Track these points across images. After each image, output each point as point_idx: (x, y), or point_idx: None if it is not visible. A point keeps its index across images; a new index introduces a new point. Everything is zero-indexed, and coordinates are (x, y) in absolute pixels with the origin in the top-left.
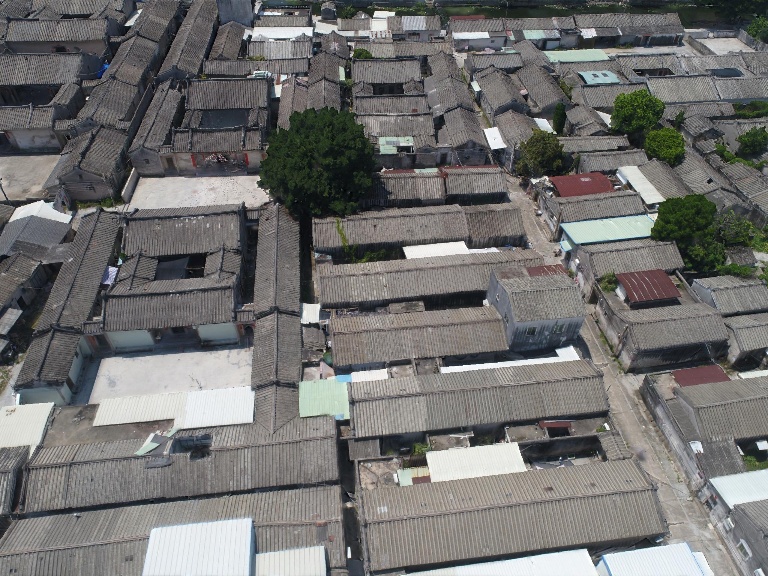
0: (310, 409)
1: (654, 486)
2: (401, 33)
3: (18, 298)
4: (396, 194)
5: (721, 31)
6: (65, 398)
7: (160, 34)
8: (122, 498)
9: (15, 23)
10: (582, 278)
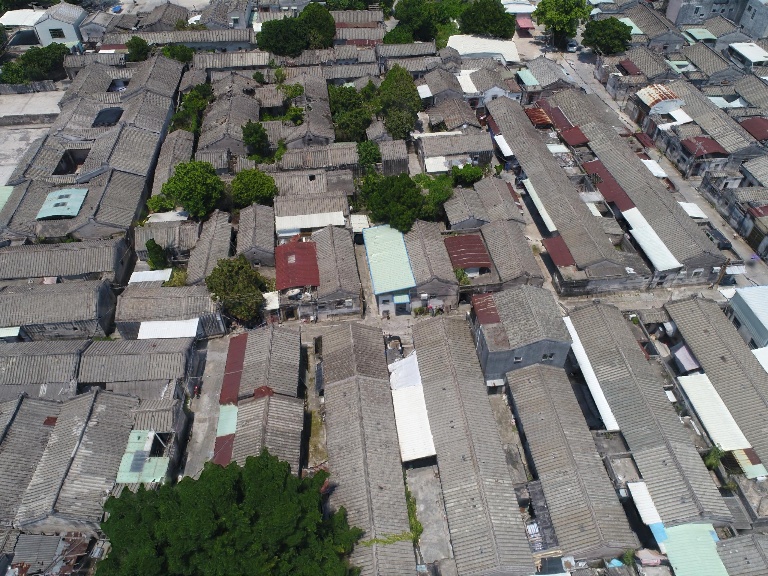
0: (719, 571)
1: (697, 295)
2: None
3: None
4: (290, 461)
5: None
6: None
7: None
8: None
9: None
10: (438, 300)
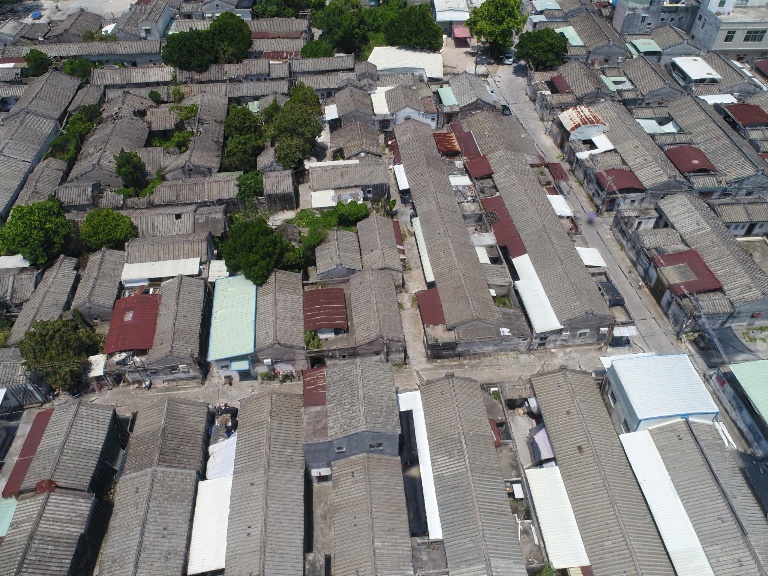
0: None
1: (566, 367)
2: None
3: None
4: (55, 575)
5: None
6: None
7: None
8: None
9: None
10: (285, 365)
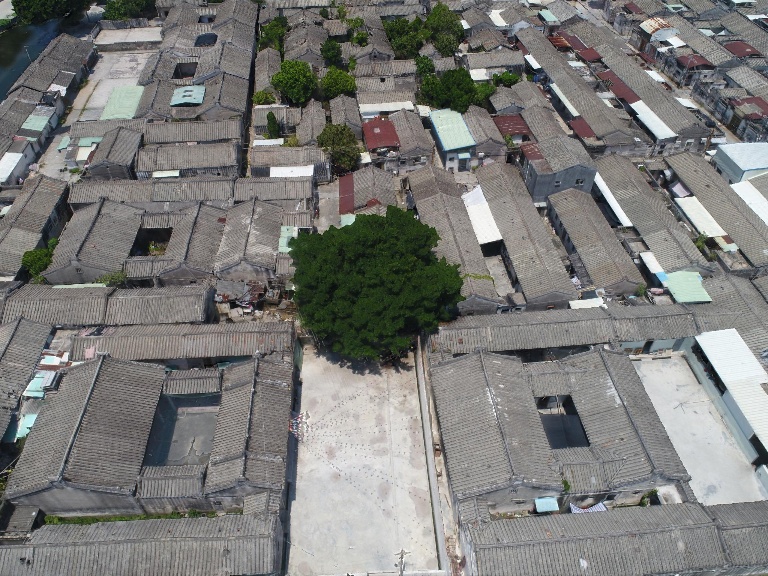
0: (703, 294)
1: None
2: None
3: None
4: None
5: (93, 30)
6: None
7: None
8: None
9: None
10: (491, 160)
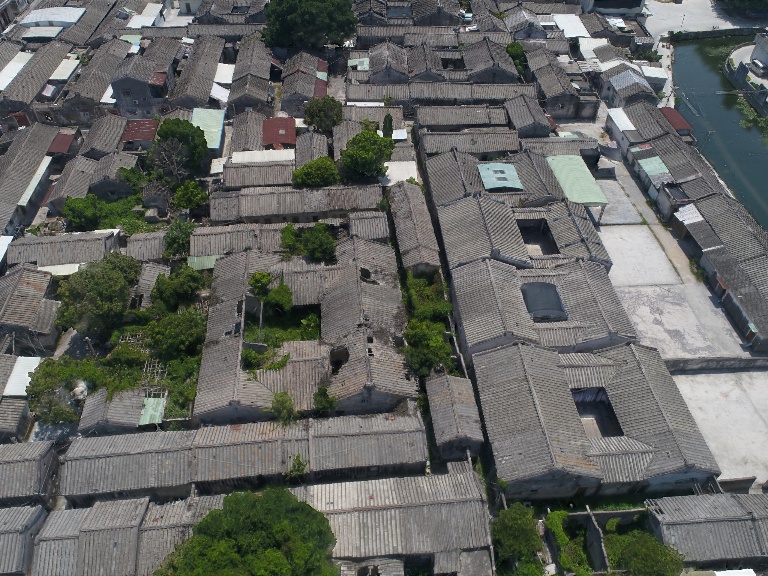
0: None
1: None
2: (604, 79)
3: None
4: None
5: None
6: (181, 9)
7: None
8: (111, 11)
9: None
10: None
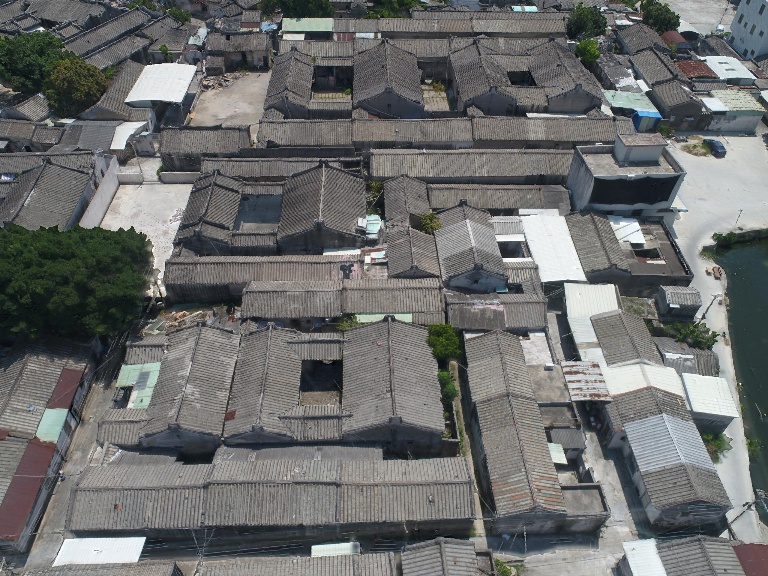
0: None
1: None
2: (614, 422)
3: (26, 145)
4: (0, 377)
5: None
6: None
7: (496, 137)
8: None
9: (474, 47)
10: None
